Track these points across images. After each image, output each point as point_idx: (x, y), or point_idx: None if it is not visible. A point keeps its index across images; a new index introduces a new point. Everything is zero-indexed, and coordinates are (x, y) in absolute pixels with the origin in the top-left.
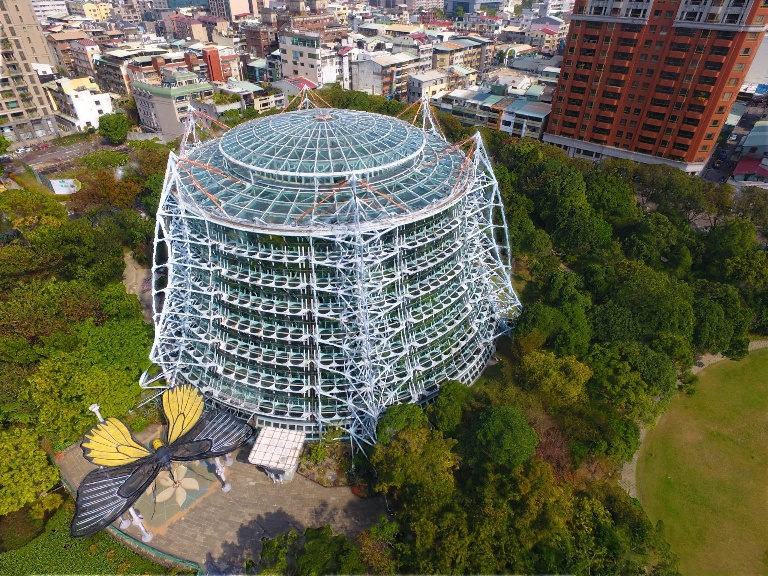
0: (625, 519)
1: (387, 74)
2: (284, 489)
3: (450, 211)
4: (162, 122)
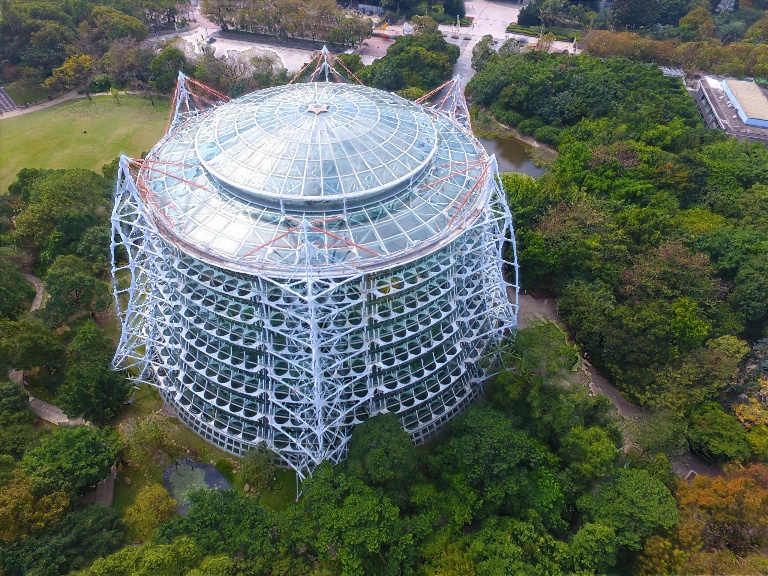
0: None
1: None
2: None
3: None
4: None
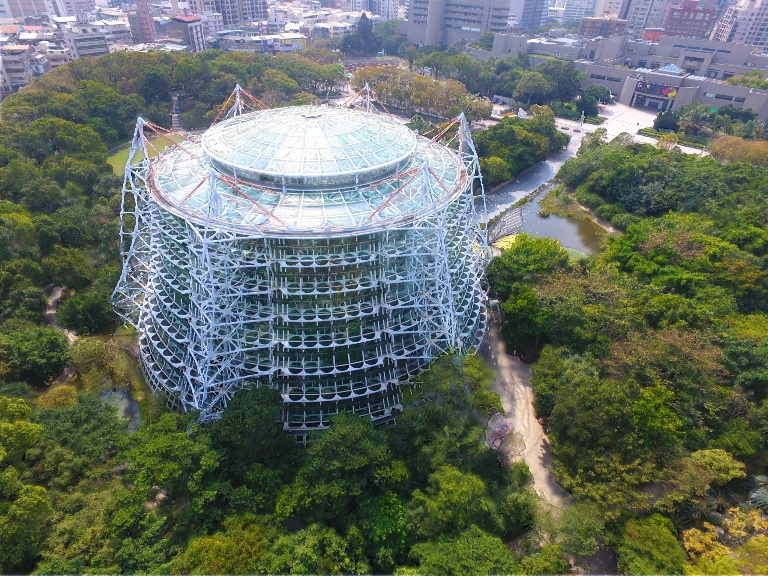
0: None
1: None
2: None
3: None
4: None
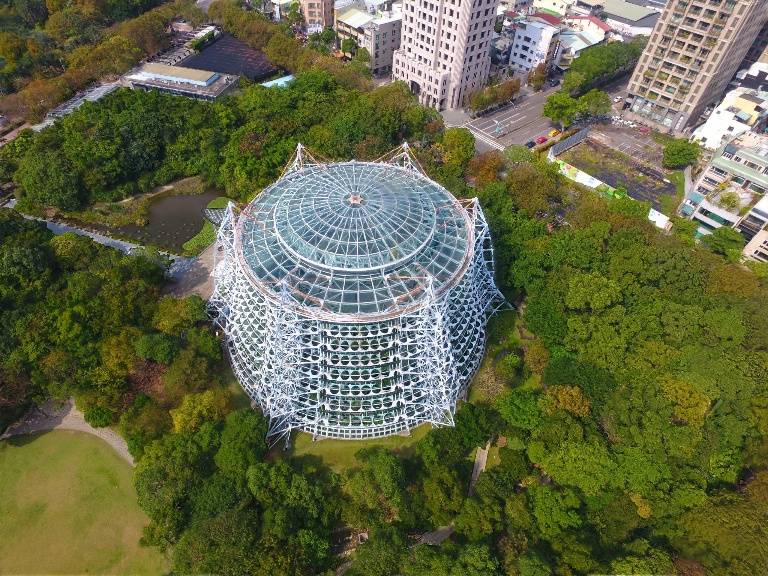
0: None
1: None
2: (217, 282)
3: None
4: None
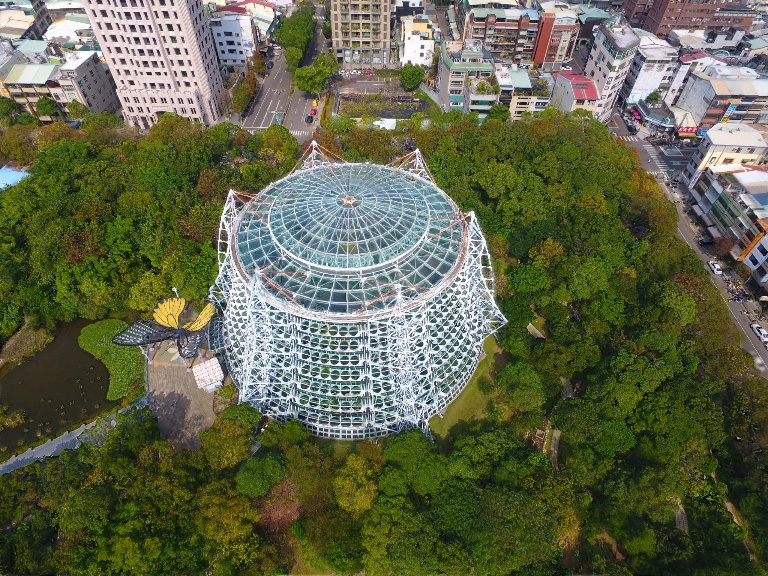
0: (246, 574)
1: (720, 105)
2: (202, 394)
3: (355, 324)
4: (441, 86)
